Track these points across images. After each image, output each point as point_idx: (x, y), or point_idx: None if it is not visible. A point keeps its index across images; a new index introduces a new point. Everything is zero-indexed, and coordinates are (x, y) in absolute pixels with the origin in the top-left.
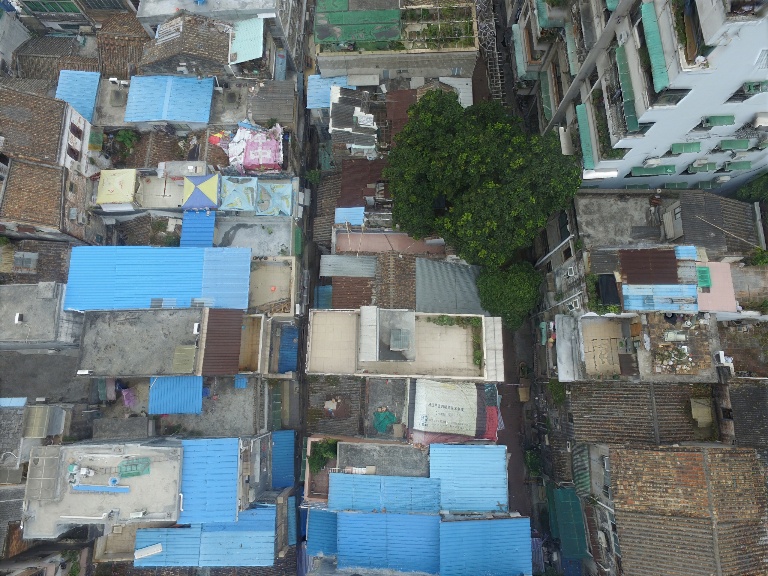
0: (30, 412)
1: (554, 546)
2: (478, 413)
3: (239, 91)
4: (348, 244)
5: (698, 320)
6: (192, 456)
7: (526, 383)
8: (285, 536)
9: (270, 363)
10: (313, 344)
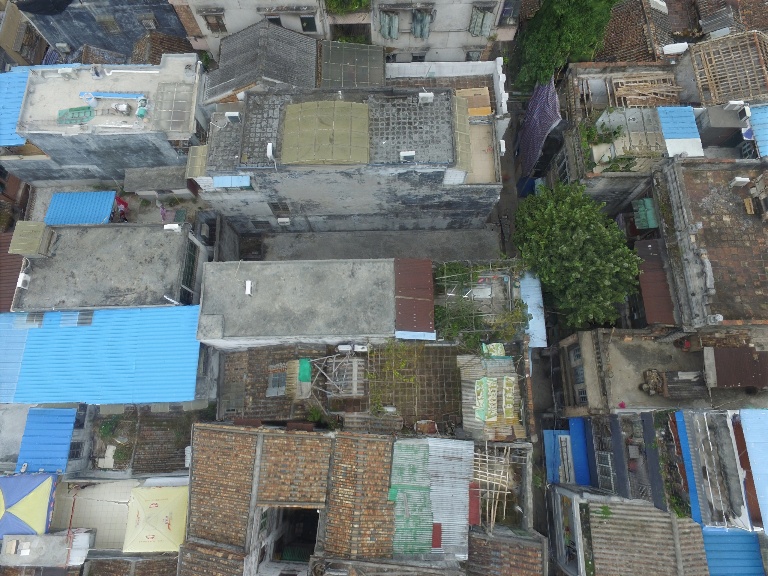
0: None
1: None
2: None
3: None
4: None
5: None
6: None
7: None
8: None
9: None
10: None
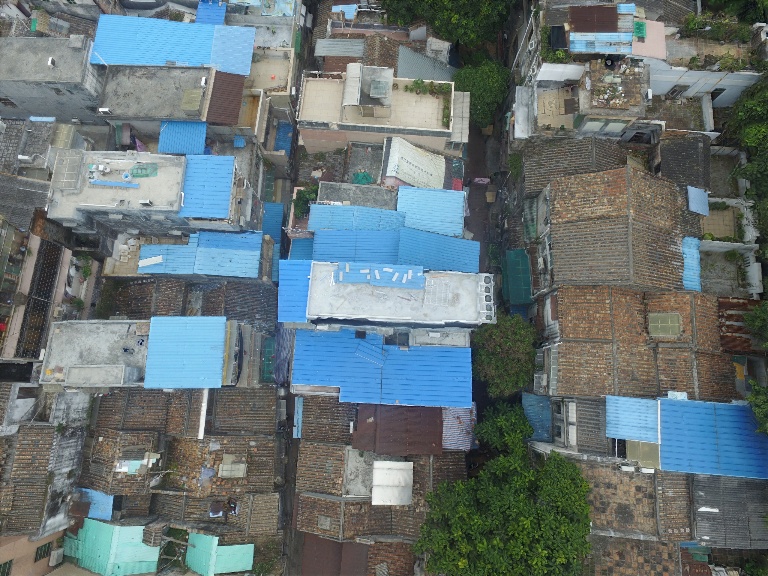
0: (58, 128)
1: (505, 313)
2: (445, 181)
3: None
4: None
5: (633, 66)
6: (194, 167)
7: (493, 188)
8: (269, 273)
9: (266, 143)
10: (304, 105)
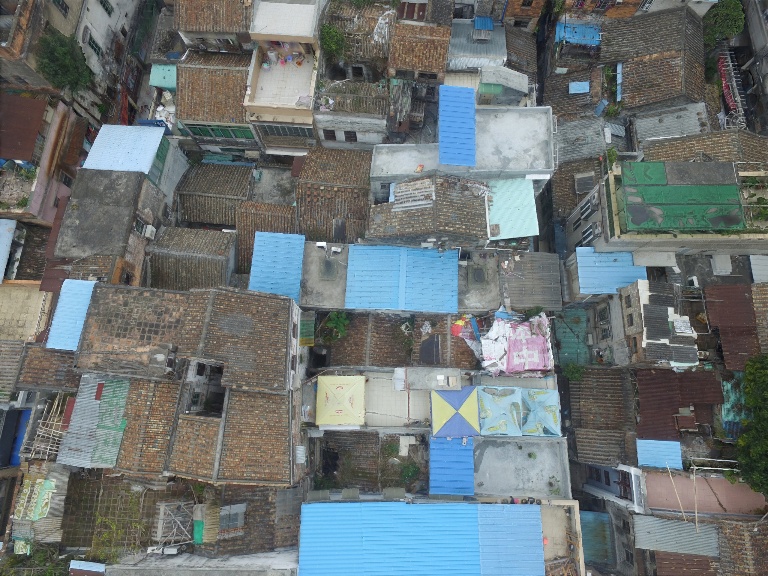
0: None
1: None
2: None
3: (484, 263)
4: (655, 490)
5: None
6: None
7: None
8: None
9: None
10: None
